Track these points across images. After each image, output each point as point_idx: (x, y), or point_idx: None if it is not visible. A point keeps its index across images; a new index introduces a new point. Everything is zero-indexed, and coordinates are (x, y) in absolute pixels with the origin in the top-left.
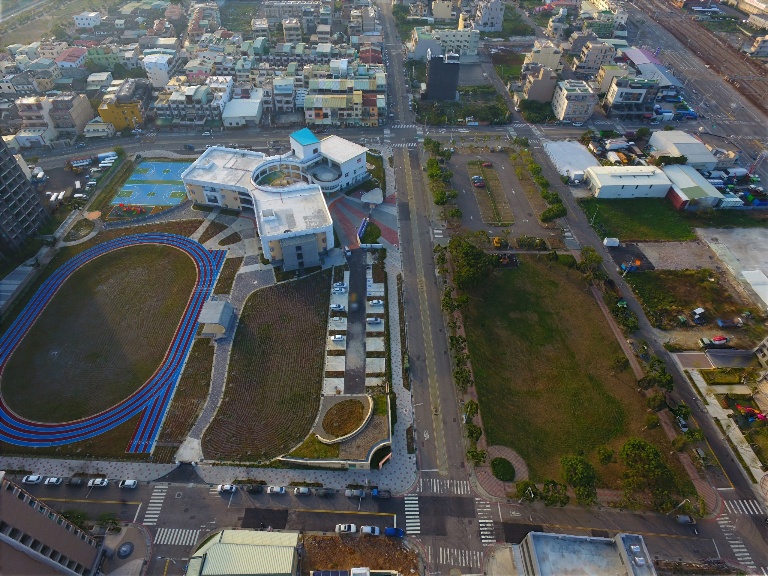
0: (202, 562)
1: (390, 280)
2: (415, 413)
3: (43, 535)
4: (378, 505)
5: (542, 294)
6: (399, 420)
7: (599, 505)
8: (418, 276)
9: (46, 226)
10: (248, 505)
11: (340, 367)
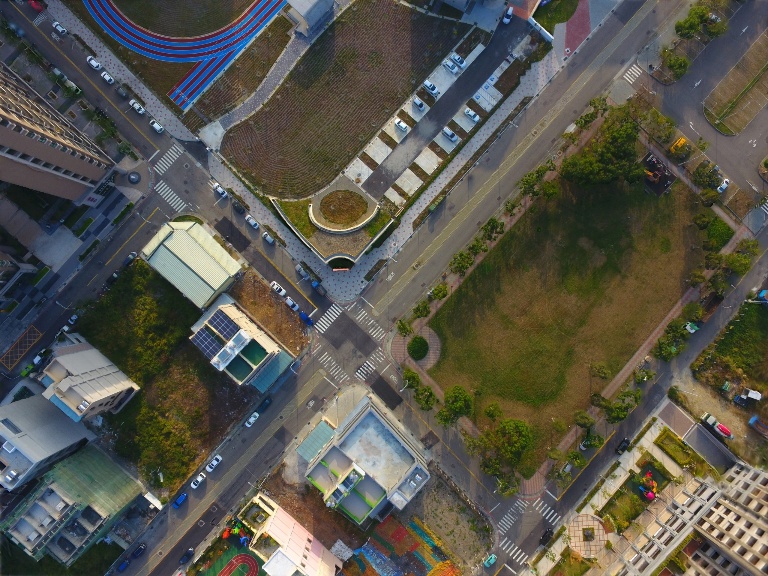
0: (167, 235)
1: (513, 97)
2: (400, 253)
3: (45, 156)
4: (311, 293)
5: (639, 246)
6: (382, 247)
7: (455, 425)
8: (546, 116)
9: None
10: (227, 215)
11: (379, 158)
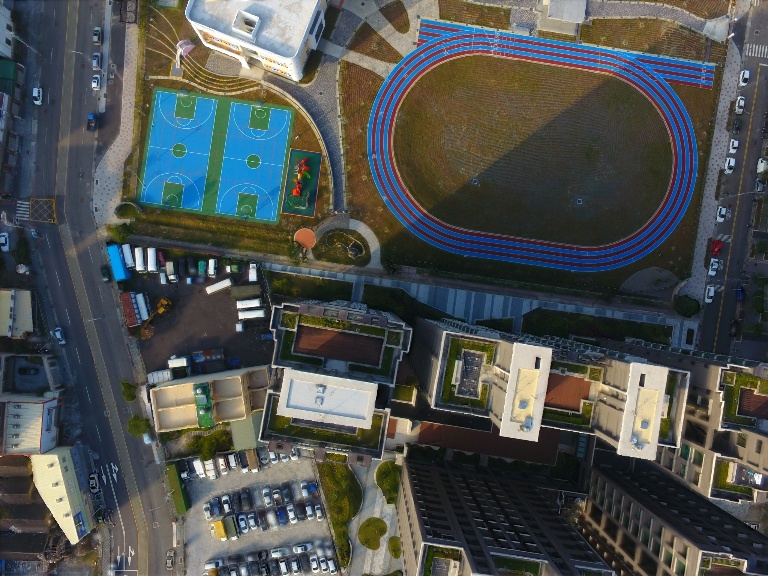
0: None
1: None
2: None
3: None
4: None
5: None
6: None
7: None
8: None
9: (332, 299)
10: None
11: None
